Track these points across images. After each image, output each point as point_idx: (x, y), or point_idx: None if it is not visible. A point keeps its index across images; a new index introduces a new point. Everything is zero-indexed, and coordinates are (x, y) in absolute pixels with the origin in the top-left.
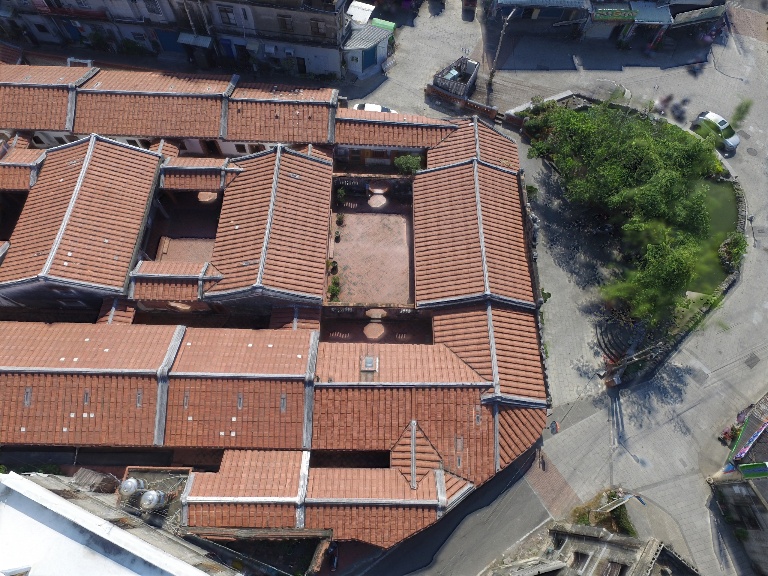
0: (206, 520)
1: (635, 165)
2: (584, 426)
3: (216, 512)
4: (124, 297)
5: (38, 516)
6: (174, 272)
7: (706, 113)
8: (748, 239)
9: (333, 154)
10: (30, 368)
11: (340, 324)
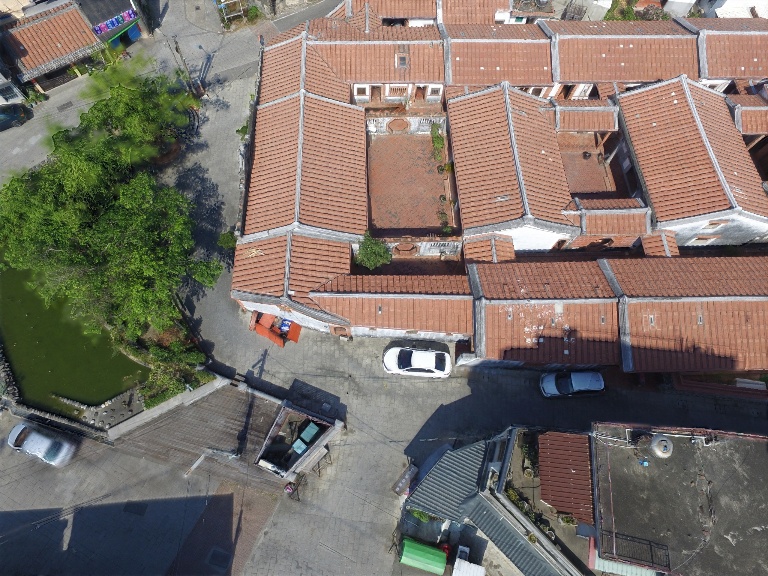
0: None
1: None
2: (233, 64)
3: None
4: None
5: None
6: (583, 116)
7: None
8: None
9: None
10: (649, 36)
11: None
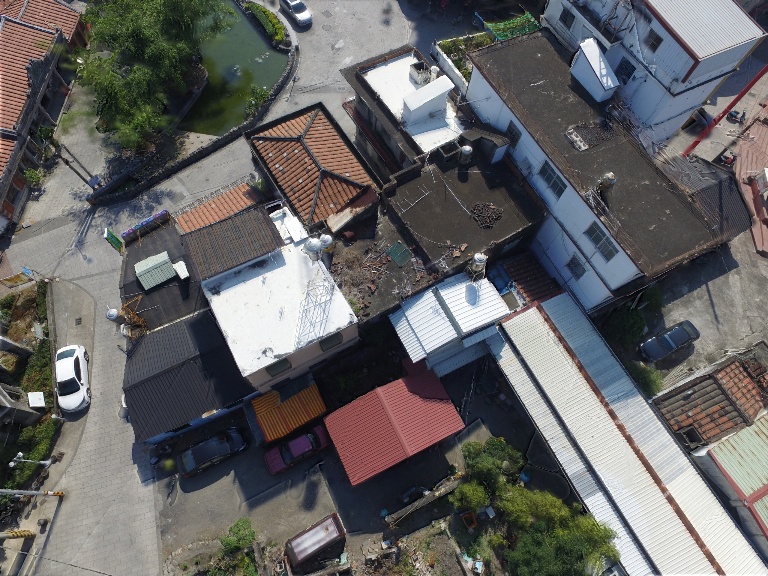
0: None
1: None
2: (52, 234)
3: None
4: None
5: None
6: None
7: None
8: (284, 95)
9: None
10: None
11: None
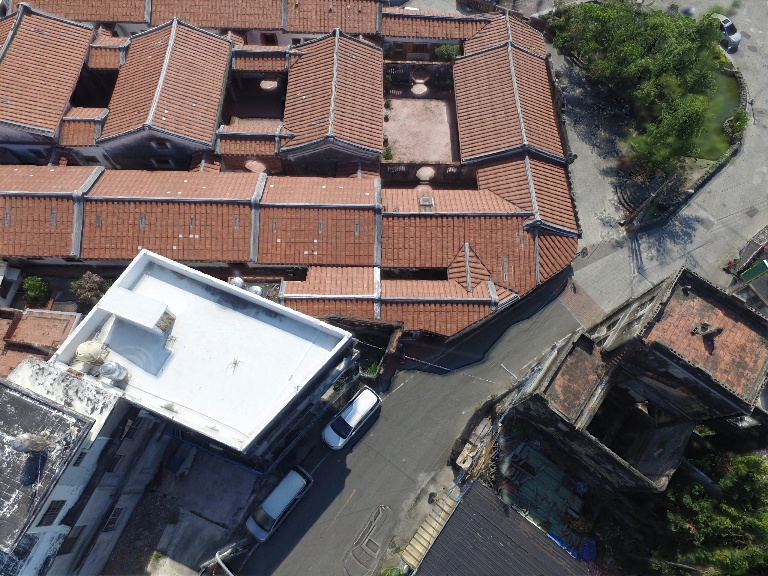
0: None
1: (650, 45)
2: (608, 260)
3: (308, 307)
4: (211, 153)
5: (176, 284)
6: (253, 132)
7: (711, 14)
8: (749, 118)
9: None
10: (144, 197)
11: (393, 186)
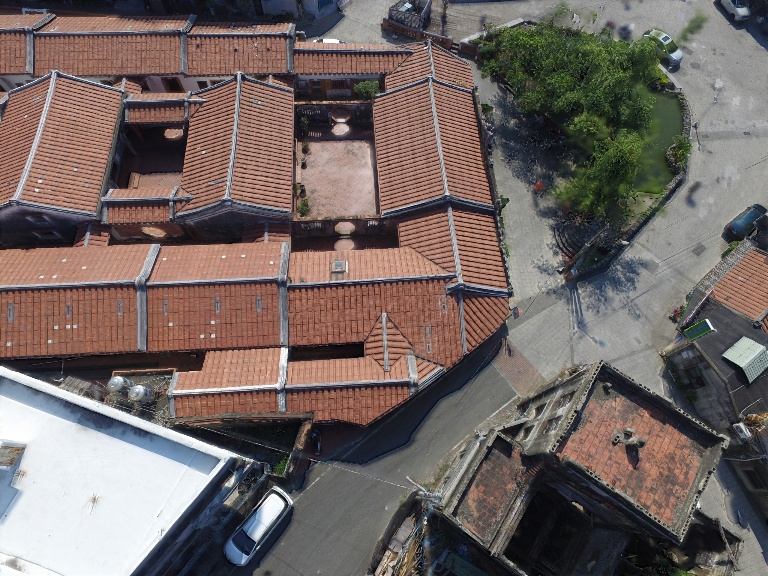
0: (192, 411)
1: (582, 74)
2: (546, 315)
3: (201, 403)
4: (98, 223)
5: (29, 402)
6: (145, 196)
7: (650, 31)
8: (693, 144)
9: (294, 87)
10: (10, 286)
11: (311, 242)
